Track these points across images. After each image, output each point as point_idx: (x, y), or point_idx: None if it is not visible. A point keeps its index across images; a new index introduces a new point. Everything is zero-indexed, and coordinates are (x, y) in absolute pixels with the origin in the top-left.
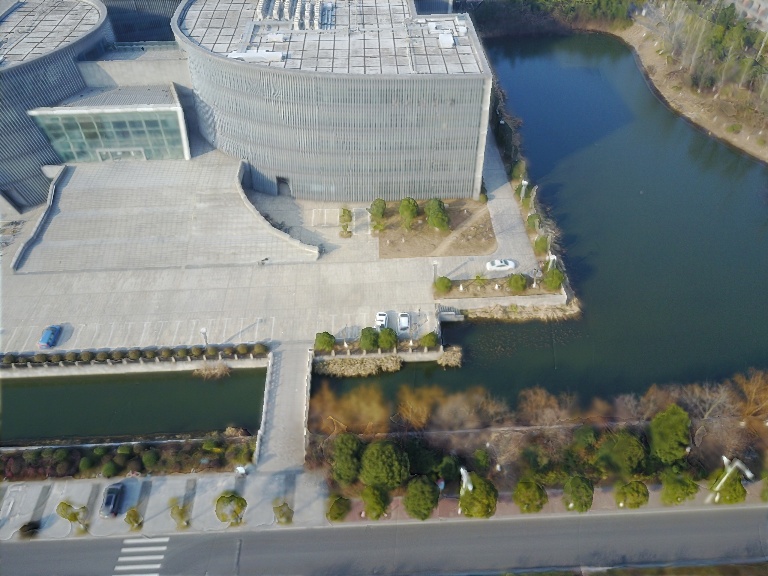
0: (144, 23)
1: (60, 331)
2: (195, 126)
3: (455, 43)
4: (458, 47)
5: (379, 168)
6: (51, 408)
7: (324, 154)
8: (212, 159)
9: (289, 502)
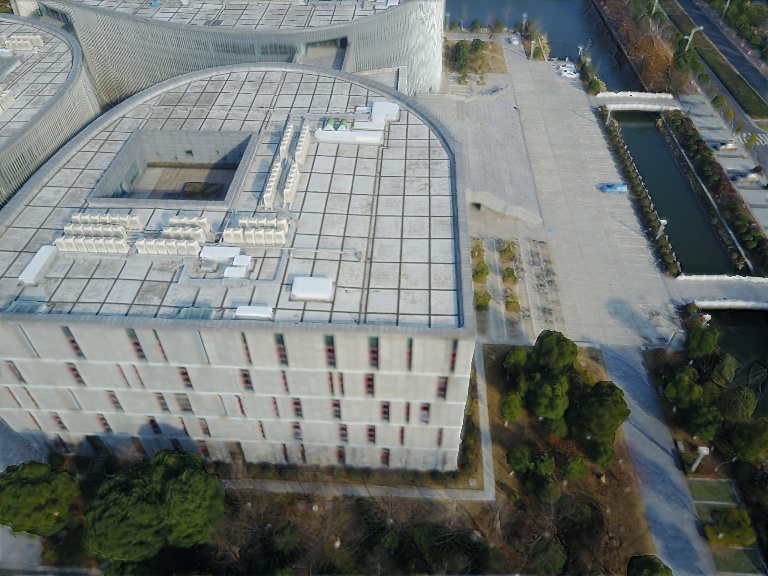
0: None
1: None
2: None
3: None
4: None
5: None
6: (664, 194)
7: None
8: None
9: (696, 103)
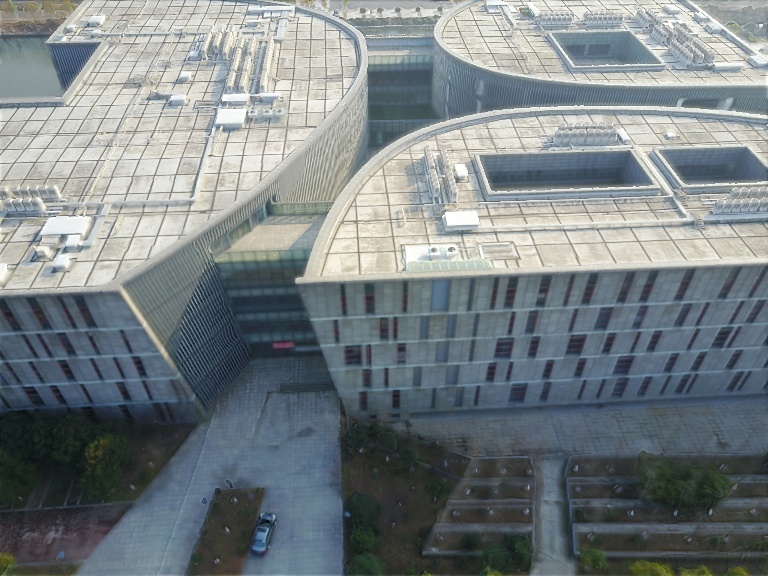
0: None
1: None
2: None
3: None
4: None
5: None
6: None
7: None
8: None
9: None
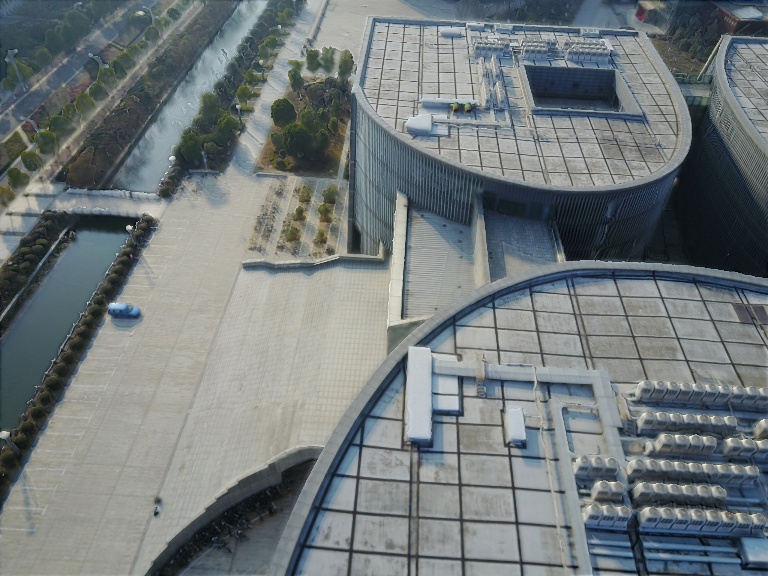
0: None
1: (131, 317)
2: None
3: None
4: None
5: None
6: (48, 334)
7: None
8: None
9: None
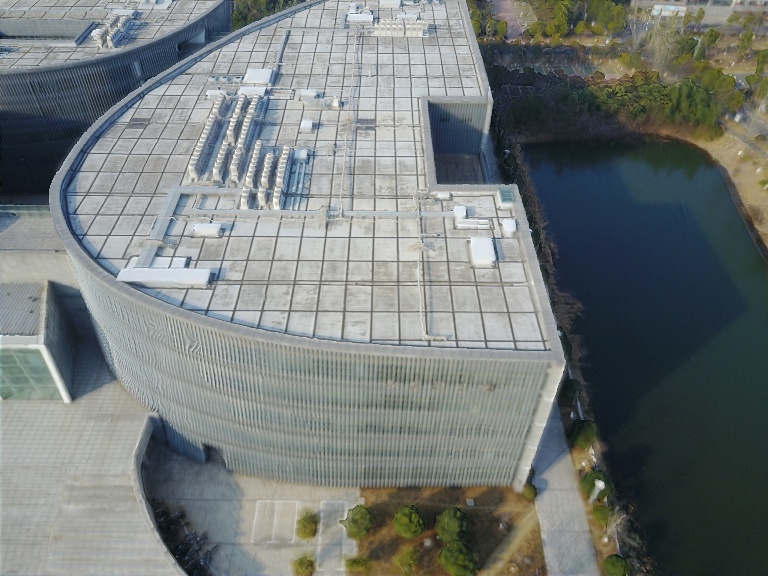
0: (55, 131)
1: None
2: (91, 332)
3: (497, 255)
4: (502, 266)
5: (364, 453)
6: None
7: (274, 431)
8: (105, 402)
9: None
